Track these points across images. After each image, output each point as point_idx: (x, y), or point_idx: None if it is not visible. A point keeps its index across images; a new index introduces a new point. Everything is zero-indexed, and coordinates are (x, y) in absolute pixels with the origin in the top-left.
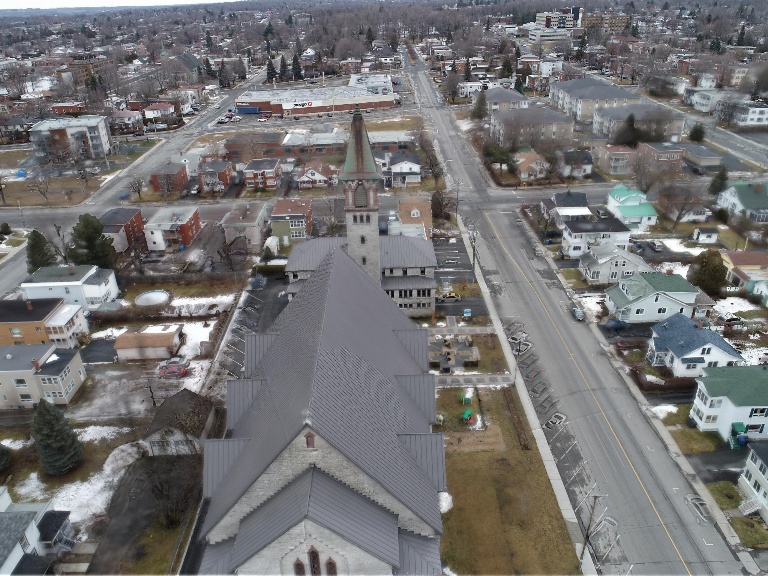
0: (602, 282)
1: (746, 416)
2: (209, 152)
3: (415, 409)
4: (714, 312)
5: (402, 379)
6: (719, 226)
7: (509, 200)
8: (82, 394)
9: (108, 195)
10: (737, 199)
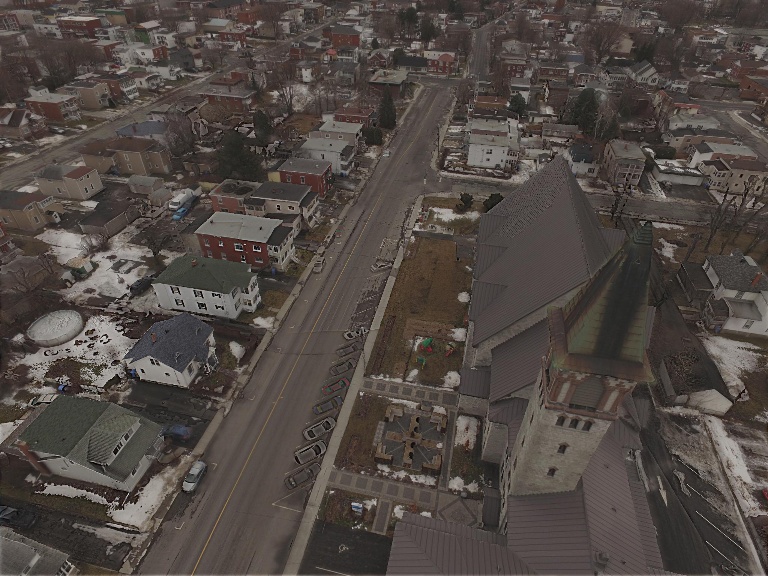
0: None
1: None
2: None
3: None
4: None
5: None
6: None
7: None
8: None
9: None
10: None
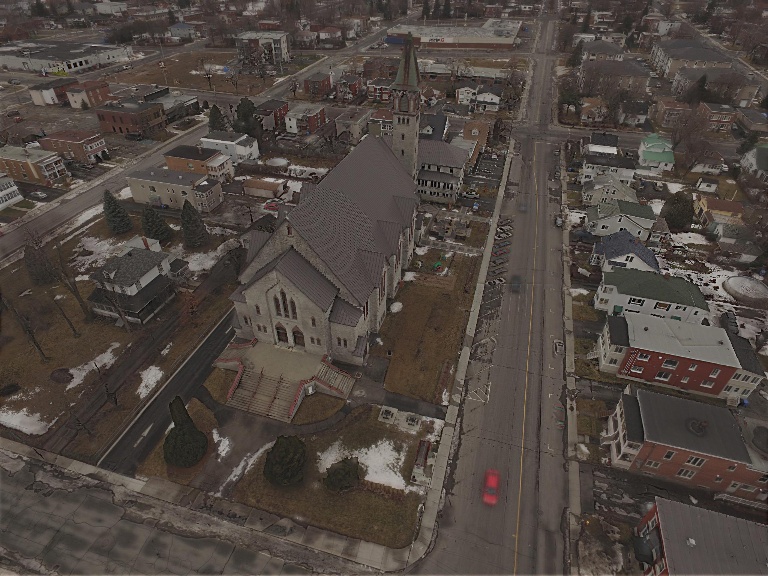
0: (593, 204)
1: (626, 302)
2: (349, 68)
3: (384, 243)
4: (670, 240)
5: (381, 223)
6: (728, 180)
7: (561, 135)
8: (219, 209)
9: (276, 92)
10: (755, 160)
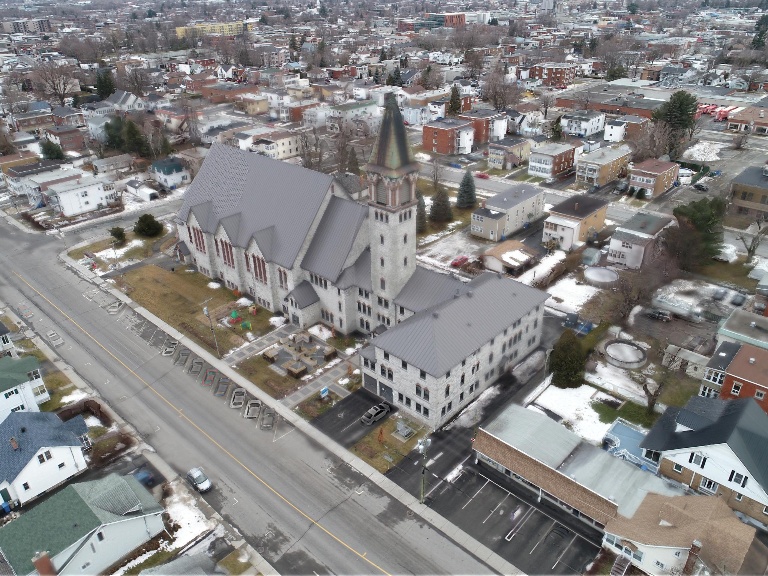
0: None
1: None
2: None
3: None
4: None
5: None
6: None
7: None
8: None
9: None
10: None
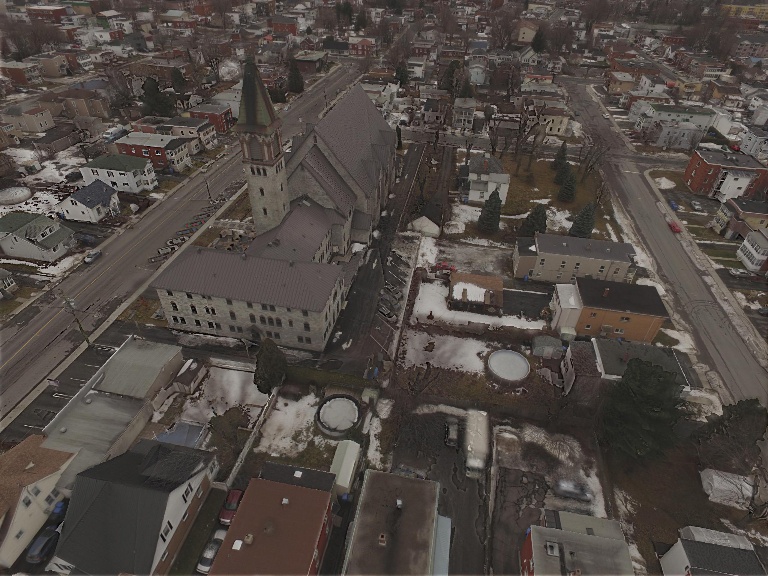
0: None
1: None
2: None
3: None
4: None
5: None
6: None
7: None
8: (508, 265)
9: None
10: None
